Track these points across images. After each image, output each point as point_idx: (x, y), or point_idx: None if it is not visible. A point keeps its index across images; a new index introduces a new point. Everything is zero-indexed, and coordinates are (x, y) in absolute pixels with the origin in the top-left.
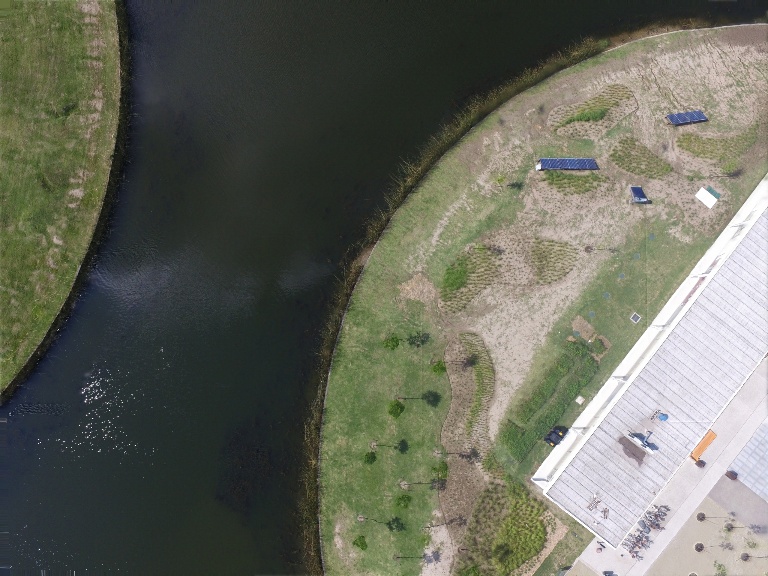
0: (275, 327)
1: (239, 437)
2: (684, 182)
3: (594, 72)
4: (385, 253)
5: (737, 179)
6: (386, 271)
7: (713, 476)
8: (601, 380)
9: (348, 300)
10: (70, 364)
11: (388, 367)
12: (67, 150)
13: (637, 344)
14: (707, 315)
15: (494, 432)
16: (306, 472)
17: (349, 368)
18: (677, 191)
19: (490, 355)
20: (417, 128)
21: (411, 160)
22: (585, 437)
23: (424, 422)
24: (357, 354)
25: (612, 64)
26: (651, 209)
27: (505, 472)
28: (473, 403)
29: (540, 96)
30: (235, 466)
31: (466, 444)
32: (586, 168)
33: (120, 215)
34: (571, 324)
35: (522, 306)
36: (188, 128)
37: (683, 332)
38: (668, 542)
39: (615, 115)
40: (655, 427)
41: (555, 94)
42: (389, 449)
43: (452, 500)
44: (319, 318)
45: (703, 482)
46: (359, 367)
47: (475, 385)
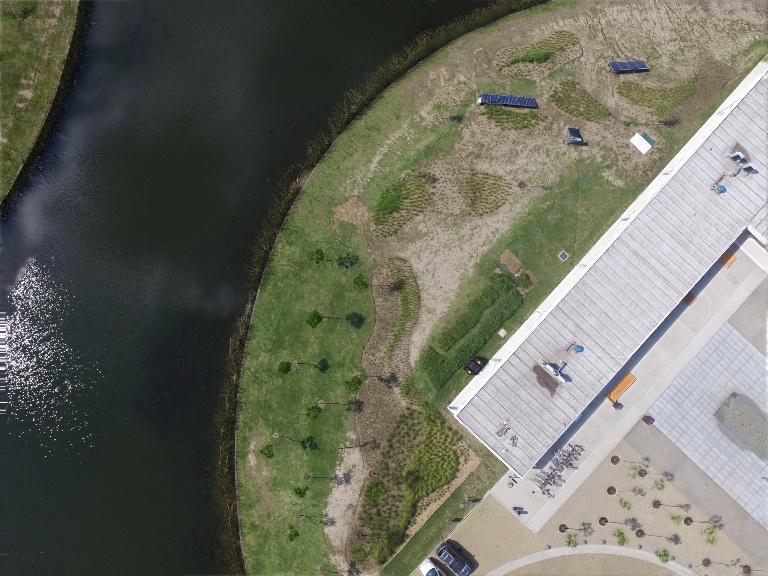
0: (210, 241)
1: (164, 347)
2: (620, 127)
3: (543, 18)
4: (324, 176)
5: (673, 128)
6: (323, 193)
7: (630, 420)
8: (525, 314)
9: (283, 219)
10: (3, 261)
11: (316, 287)
12: (21, 51)
13: (563, 282)
14: (629, 252)
15: (415, 358)
16: (227, 387)
17: (278, 286)
18: (613, 135)
19: (417, 281)
20: (367, 59)
21: (357, 88)
22: (500, 363)
23: (346, 343)
24: (287, 272)
25: (561, 12)
26: (586, 151)
27: (422, 399)
28: (396, 327)
29: (488, 36)
30: (157, 376)
31: (386, 368)
32: (525, 105)
33: (67, 118)
34: (499, 257)
35: (452, 235)
36: (142, 41)
37: (604, 267)
38: (581, 483)
39: (559, 59)
40: (570, 359)
41: (503, 36)
42: (309, 367)
43: (368, 423)
44: (254, 236)
45: (620, 425)
46: (288, 285)
47: (400, 310)
